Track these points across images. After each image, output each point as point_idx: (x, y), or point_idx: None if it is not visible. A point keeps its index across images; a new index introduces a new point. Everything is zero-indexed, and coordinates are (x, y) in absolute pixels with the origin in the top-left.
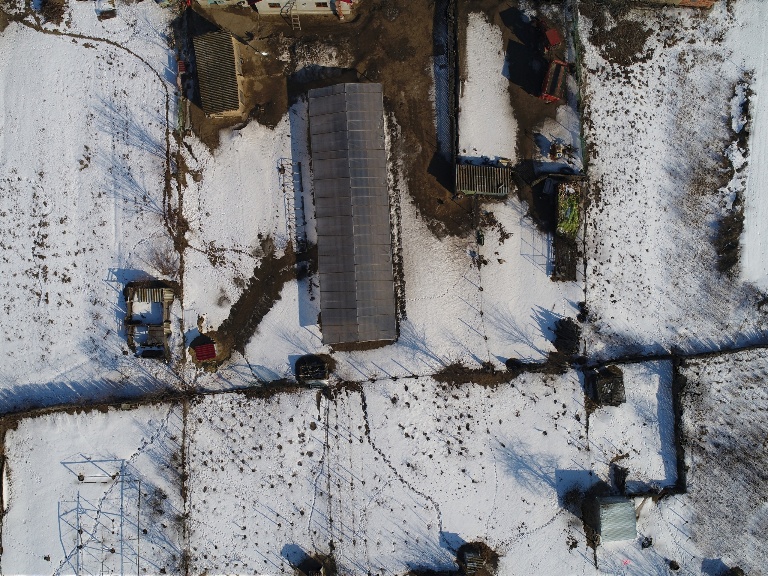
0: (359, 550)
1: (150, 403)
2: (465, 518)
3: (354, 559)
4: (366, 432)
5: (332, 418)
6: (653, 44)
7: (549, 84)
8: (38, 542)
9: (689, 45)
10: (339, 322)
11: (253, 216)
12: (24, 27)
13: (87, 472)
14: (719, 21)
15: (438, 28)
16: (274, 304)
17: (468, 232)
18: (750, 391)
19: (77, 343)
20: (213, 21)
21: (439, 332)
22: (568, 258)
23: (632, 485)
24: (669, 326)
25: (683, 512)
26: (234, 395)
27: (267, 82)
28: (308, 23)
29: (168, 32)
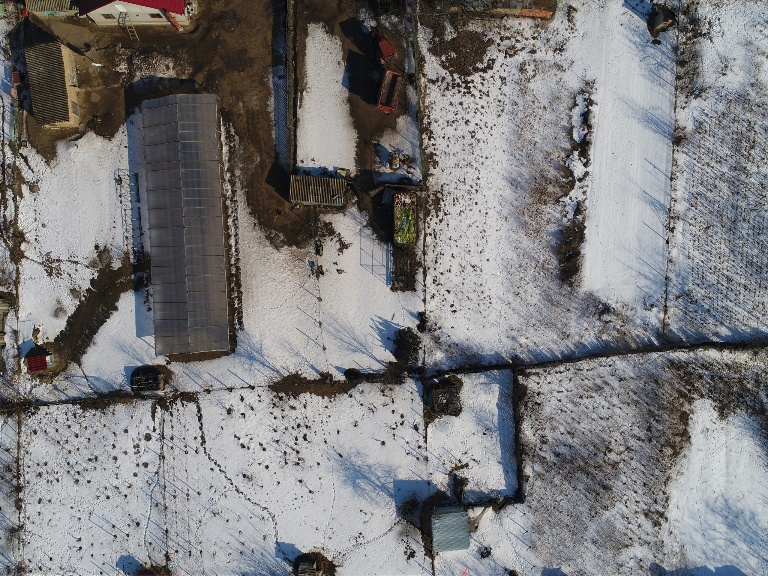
0: (194, 561)
1: None
2: (302, 528)
3: (189, 570)
4: (202, 443)
5: (167, 429)
6: (494, 54)
7: (385, 95)
8: None
9: (530, 55)
10: (171, 333)
11: (90, 227)
12: None
13: None
14: (560, 31)
15: (277, 39)
16: (111, 315)
17: (307, 242)
18: (591, 400)
19: None
20: (51, 32)
21: (277, 342)
22: (408, 268)
23: (472, 495)
24: (510, 336)
25: (523, 521)
26: (69, 406)
27: (104, 93)
28: (147, 34)
29: (4, 43)
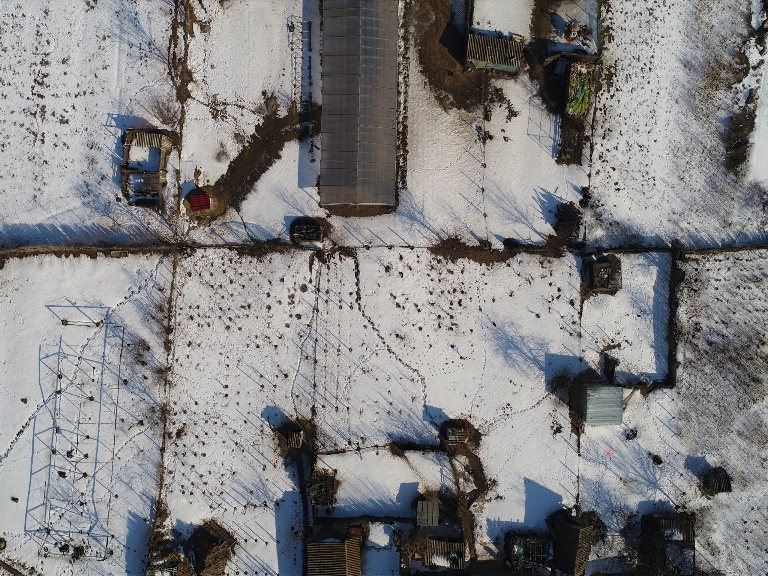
0: (341, 417)
1: (140, 252)
2: (450, 394)
3: (335, 426)
4: (357, 299)
5: (323, 282)
6: None
7: None
8: (16, 384)
9: None
10: (338, 182)
11: (259, 72)
12: None
13: (71, 317)
14: None
15: None
16: (273, 163)
17: (476, 107)
18: (748, 291)
19: (70, 186)
20: None
21: (438, 205)
22: (575, 142)
23: (621, 376)
24: (671, 219)
25: (671, 407)
26: (226, 251)
27: None
28: None
29: None
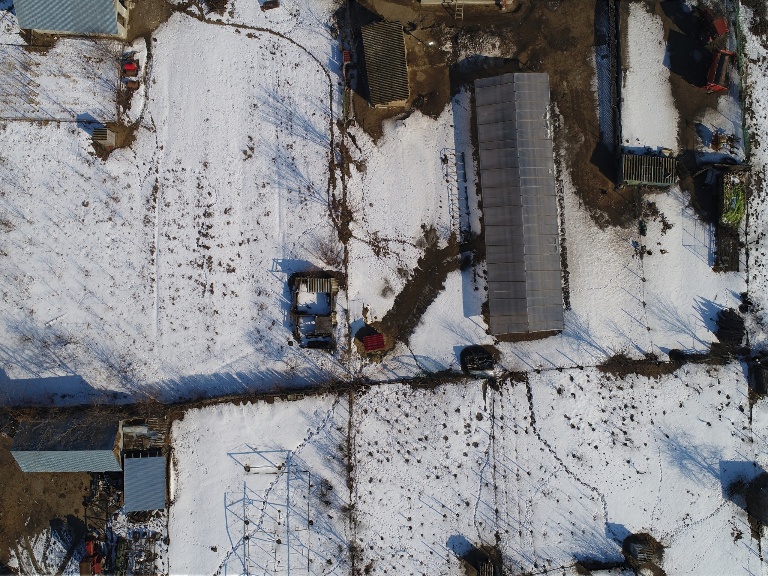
0: (525, 541)
1: (316, 394)
2: (630, 509)
3: (520, 550)
4: (531, 423)
5: (498, 409)
6: None
7: None
8: (205, 533)
9: None
10: (508, 312)
11: (416, 206)
12: (187, 17)
13: (253, 463)
14: None
15: (600, 18)
16: (438, 295)
17: (630, 222)
18: None
19: (242, 334)
20: (375, 11)
21: (603, 323)
22: (730, 249)
23: None
24: None
25: None
26: (399, 386)
27: (430, 72)
28: (469, 13)
29: (331, 22)
